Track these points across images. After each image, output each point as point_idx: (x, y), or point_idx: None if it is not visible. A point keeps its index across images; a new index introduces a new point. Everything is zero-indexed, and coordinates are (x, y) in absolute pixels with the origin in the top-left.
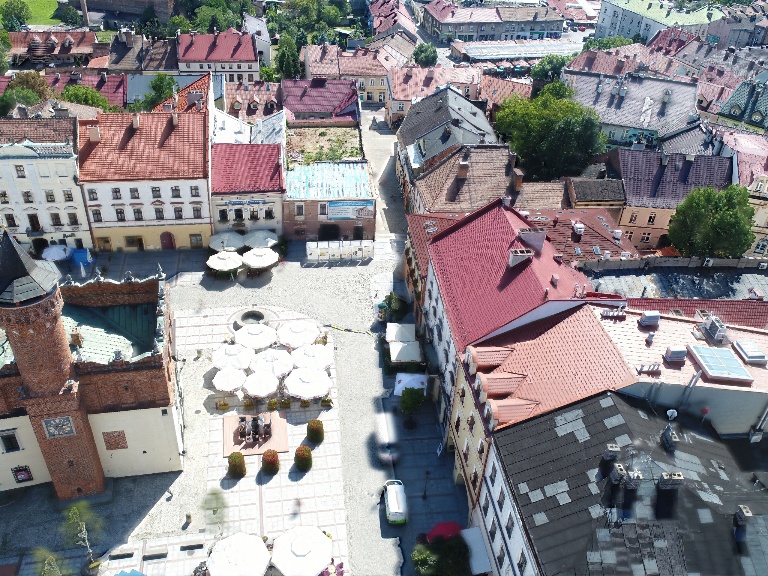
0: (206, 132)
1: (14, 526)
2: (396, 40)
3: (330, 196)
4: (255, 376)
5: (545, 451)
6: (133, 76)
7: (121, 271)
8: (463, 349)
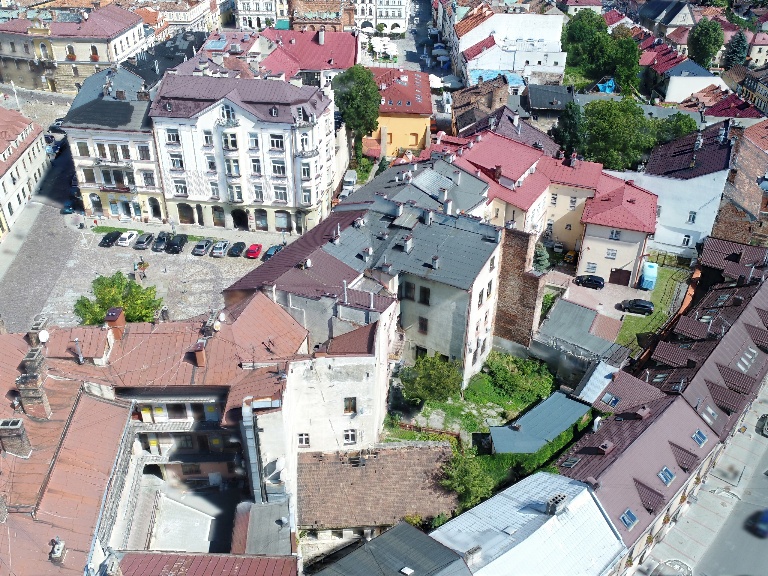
0: None
1: None
2: None
3: (474, 76)
4: None
5: None
6: (690, 60)
7: (436, 73)
8: None
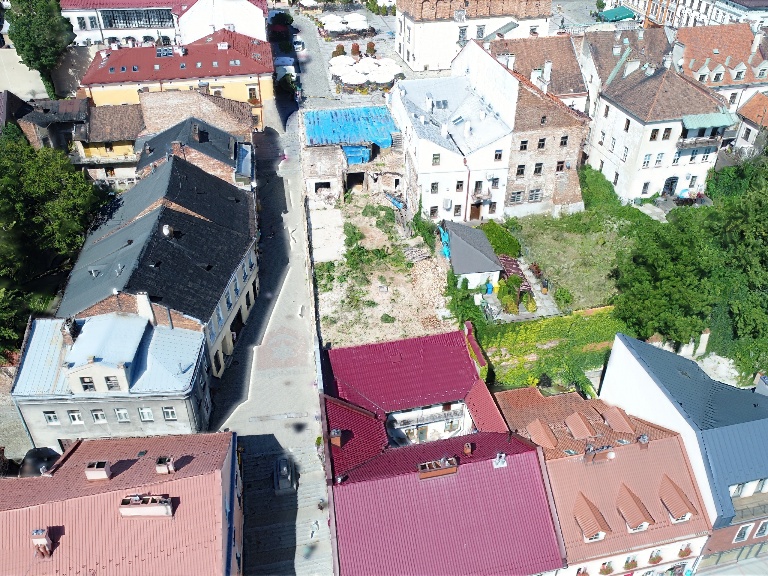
0: None
1: None
2: None
3: (345, 111)
4: (373, 60)
5: None
6: None
7: None
8: None
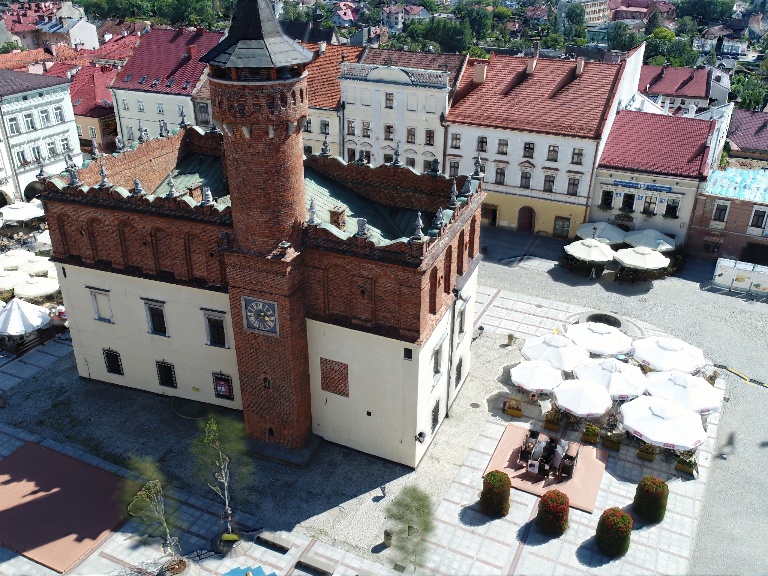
0: (615, 86)
1: (184, 445)
2: None
3: None
4: (576, 382)
5: None
6: None
7: None
8: None
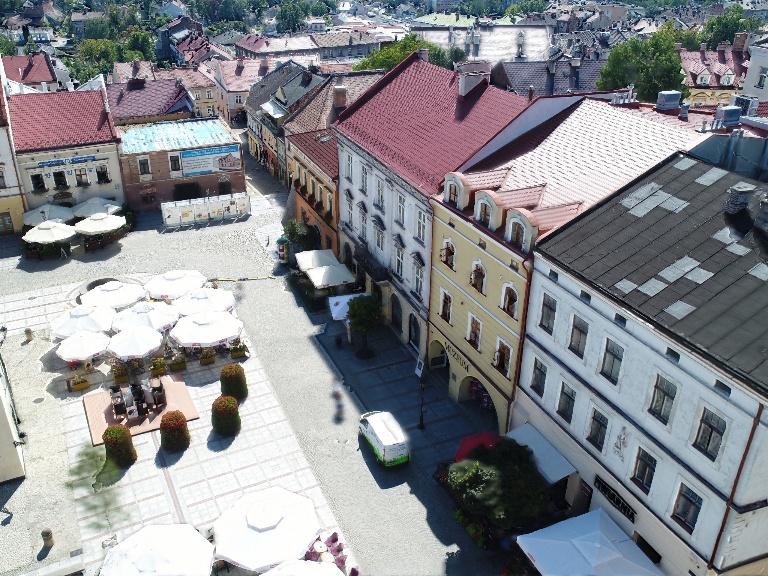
0: None
1: None
2: (214, 62)
3: (181, 146)
4: (123, 333)
5: (631, 237)
6: None
7: None
8: (435, 191)
